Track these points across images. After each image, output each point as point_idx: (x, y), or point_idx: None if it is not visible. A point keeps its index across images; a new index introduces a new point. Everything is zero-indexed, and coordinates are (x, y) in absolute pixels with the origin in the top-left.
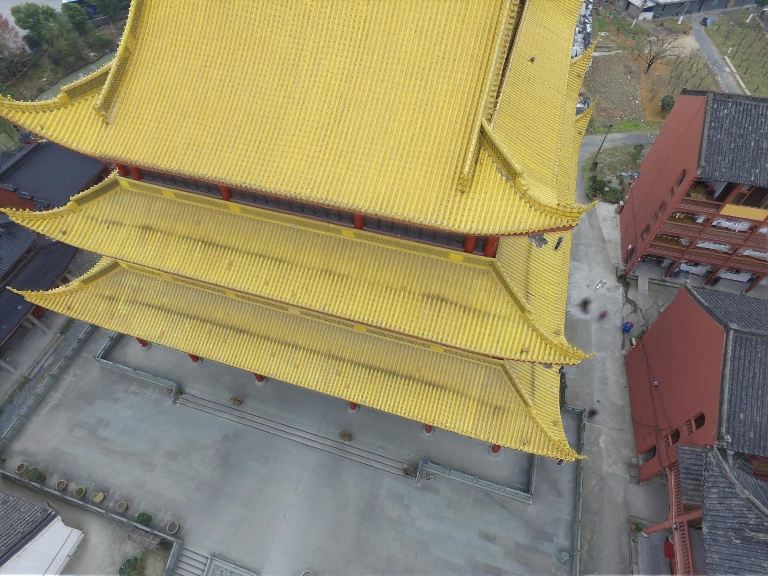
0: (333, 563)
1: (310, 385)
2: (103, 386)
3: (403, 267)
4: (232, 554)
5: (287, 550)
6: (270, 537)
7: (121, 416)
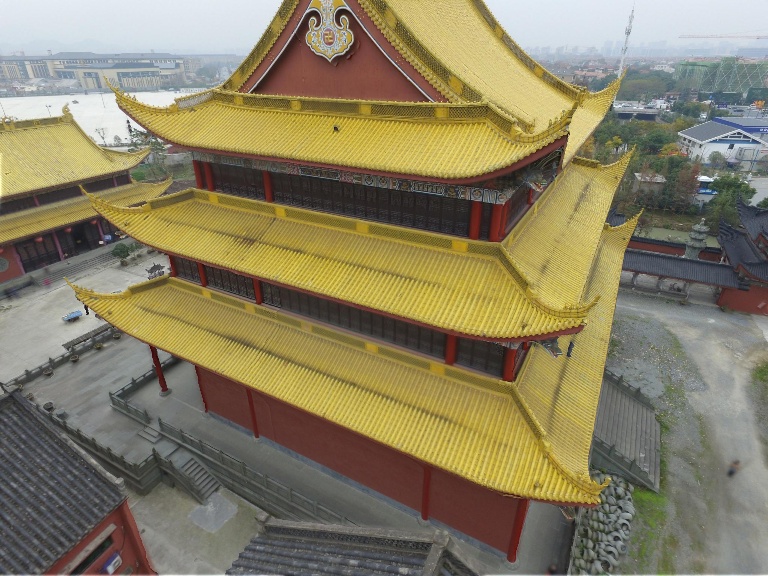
0: None
1: None
2: None
3: None
4: None
5: None
6: None
7: None
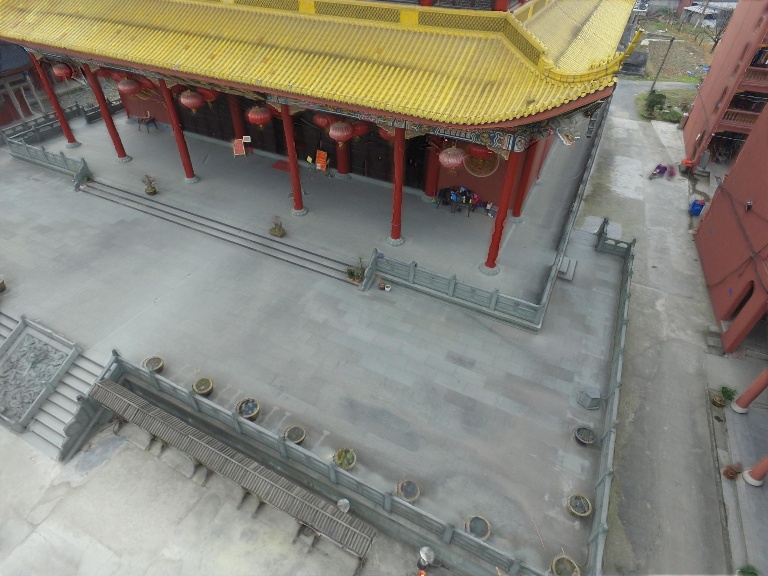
0: (202, 354)
1: (222, 72)
2: (4, 171)
3: None
4: (58, 324)
5: (140, 331)
6: (123, 315)
7: (7, 193)
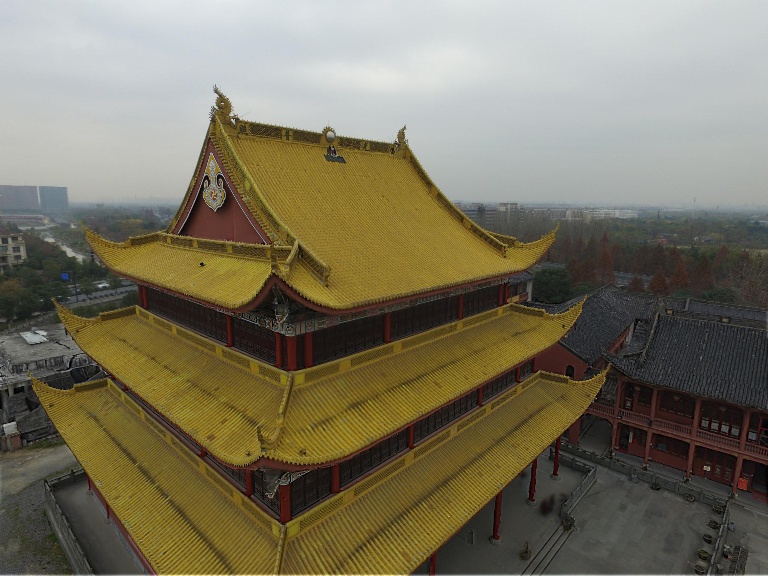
0: None
1: (519, 467)
2: None
3: (492, 330)
4: None
5: None
6: None
7: None
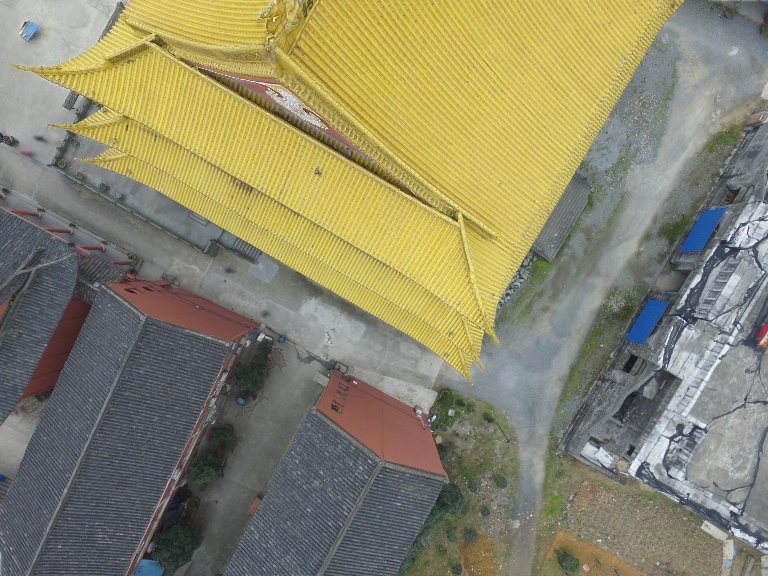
0: None
1: None
2: None
3: None
4: None
5: None
6: None
7: None
